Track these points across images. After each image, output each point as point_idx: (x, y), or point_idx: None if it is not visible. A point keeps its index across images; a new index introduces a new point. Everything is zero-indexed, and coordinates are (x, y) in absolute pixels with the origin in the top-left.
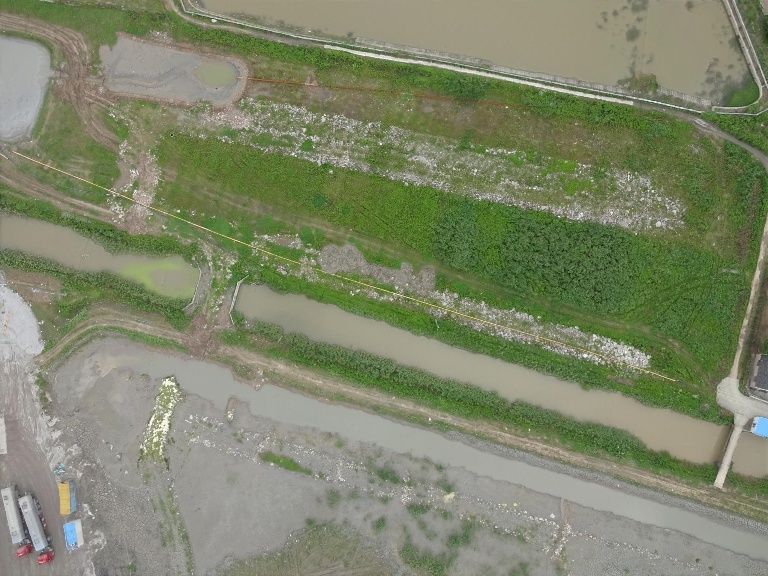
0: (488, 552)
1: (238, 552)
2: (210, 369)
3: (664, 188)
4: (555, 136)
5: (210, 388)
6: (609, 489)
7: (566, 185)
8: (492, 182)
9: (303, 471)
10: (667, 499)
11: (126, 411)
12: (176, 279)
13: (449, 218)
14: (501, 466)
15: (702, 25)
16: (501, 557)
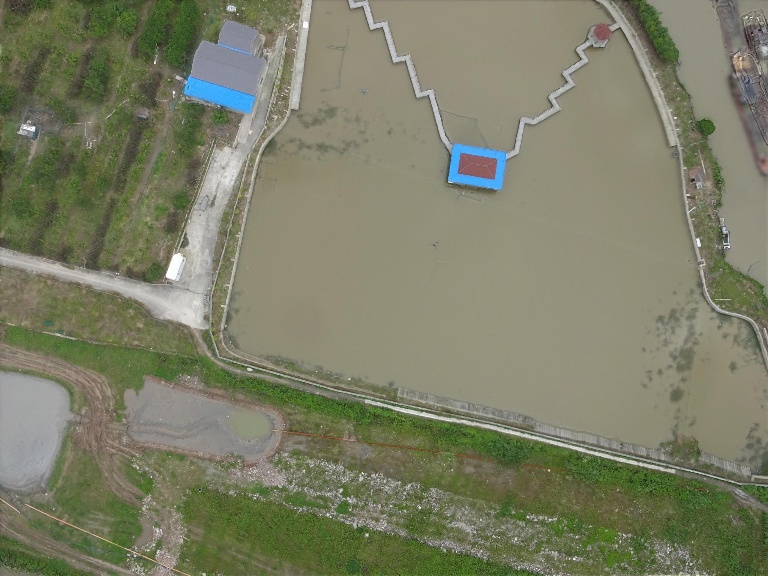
0: None
1: None
2: None
3: (702, 561)
4: (596, 503)
5: None
6: None
7: (606, 557)
8: (532, 552)
9: None
10: None
11: None
12: None
13: None
14: None
15: (745, 388)
16: None
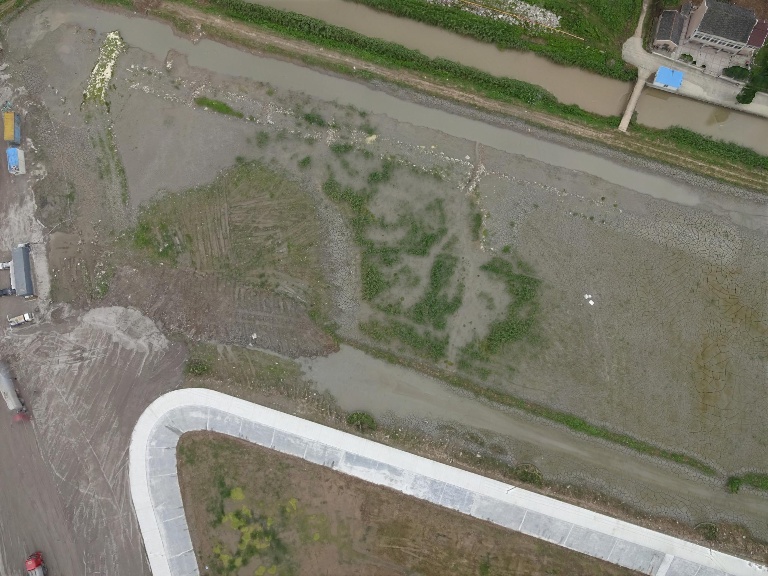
0: (406, 189)
1: (171, 186)
2: (152, 26)
3: None
4: None
5: (151, 42)
6: (521, 135)
7: None
8: None
9: (235, 114)
10: (575, 143)
11: (72, 61)
12: None
13: None
14: (420, 113)
15: None
16: (418, 193)
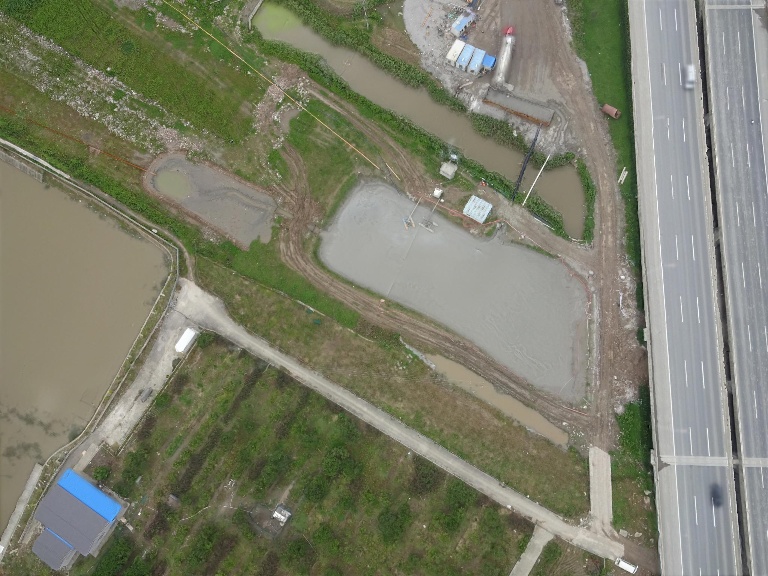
0: None
1: None
2: None
3: None
4: None
5: None
6: None
7: None
8: None
9: None
10: None
11: None
12: (275, 22)
13: (28, 1)
14: None
15: None
16: None
